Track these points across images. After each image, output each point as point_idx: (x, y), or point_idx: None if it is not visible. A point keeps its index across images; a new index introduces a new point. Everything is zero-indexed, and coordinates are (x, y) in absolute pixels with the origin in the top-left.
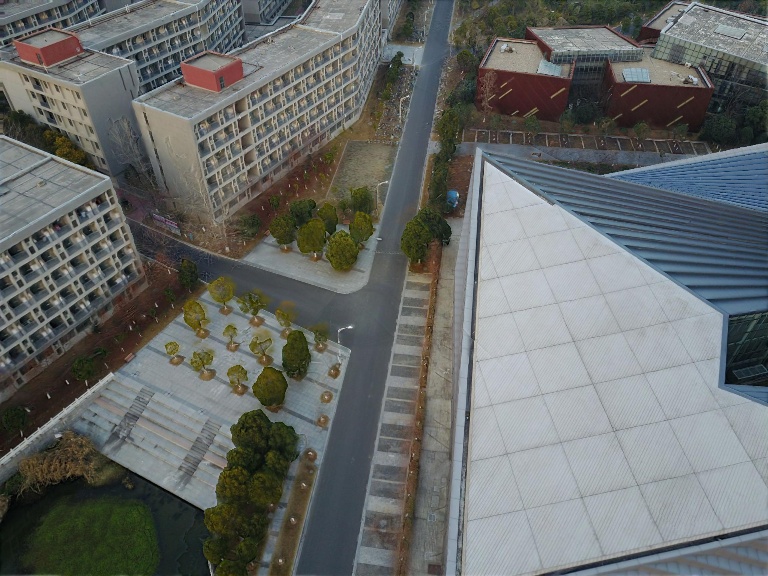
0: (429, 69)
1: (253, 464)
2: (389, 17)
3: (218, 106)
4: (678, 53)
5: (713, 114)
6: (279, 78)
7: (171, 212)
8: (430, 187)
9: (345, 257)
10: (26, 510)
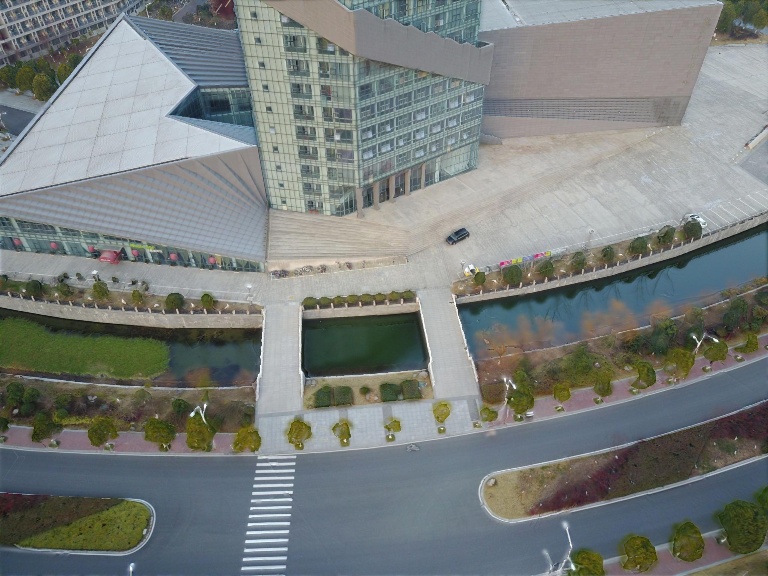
0: None
1: None
2: None
3: None
4: None
5: None
6: None
7: None
8: None
9: (43, 90)
10: None
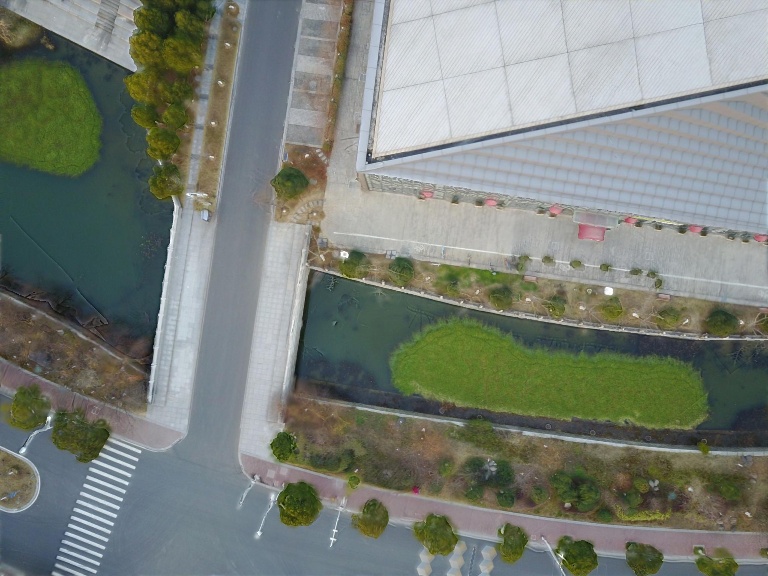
0: None
1: (163, 26)
2: None
3: None
4: None
5: None
6: None
7: None
8: None
9: None
10: None
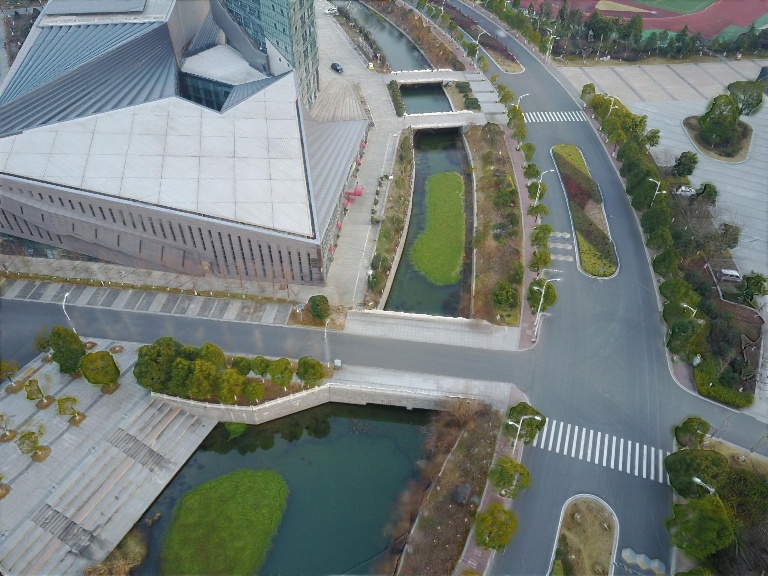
0: None
1: None
2: None
3: None
4: None
5: None
6: None
7: None
8: None
9: None
10: None
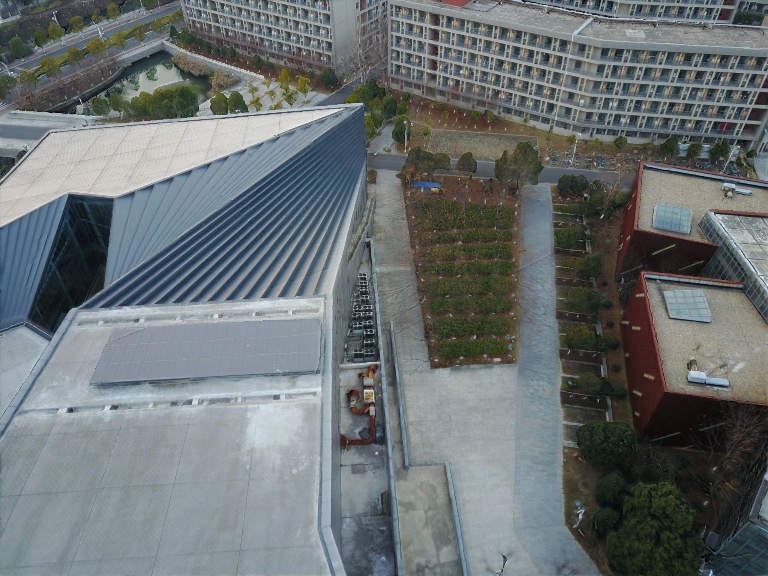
0: None
1: None
2: None
3: (413, 4)
4: None
5: None
6: (482, 25)
7: None
8: None
9: None
10: (203, 81)
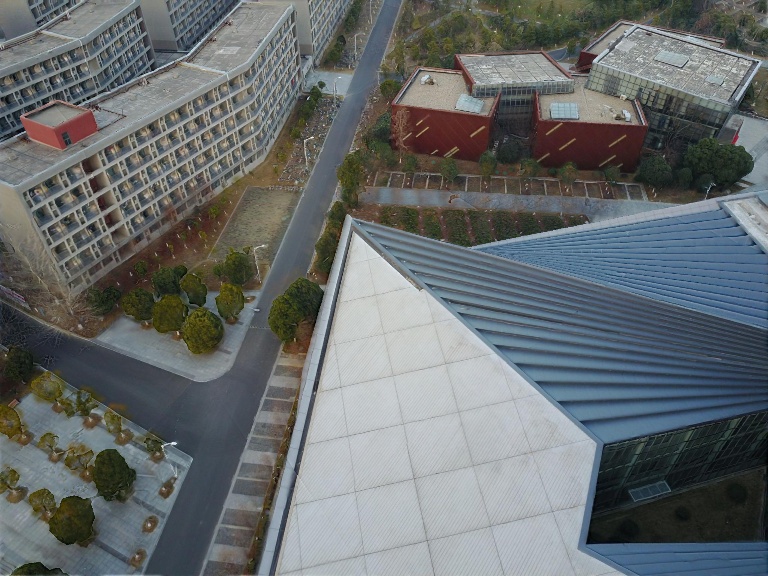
0: (354, 99)
1: None
2: (316, 42)
3: (56, 168)
4: (612, 84)
5: (653, 150)
6: (144, 128)
7: (26, 281)
8: (316, 249)
9: (202, 340)
10: None
